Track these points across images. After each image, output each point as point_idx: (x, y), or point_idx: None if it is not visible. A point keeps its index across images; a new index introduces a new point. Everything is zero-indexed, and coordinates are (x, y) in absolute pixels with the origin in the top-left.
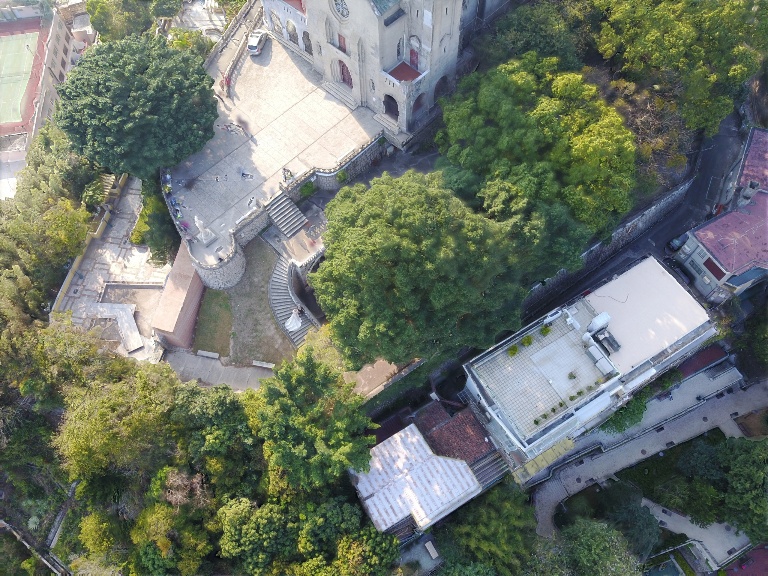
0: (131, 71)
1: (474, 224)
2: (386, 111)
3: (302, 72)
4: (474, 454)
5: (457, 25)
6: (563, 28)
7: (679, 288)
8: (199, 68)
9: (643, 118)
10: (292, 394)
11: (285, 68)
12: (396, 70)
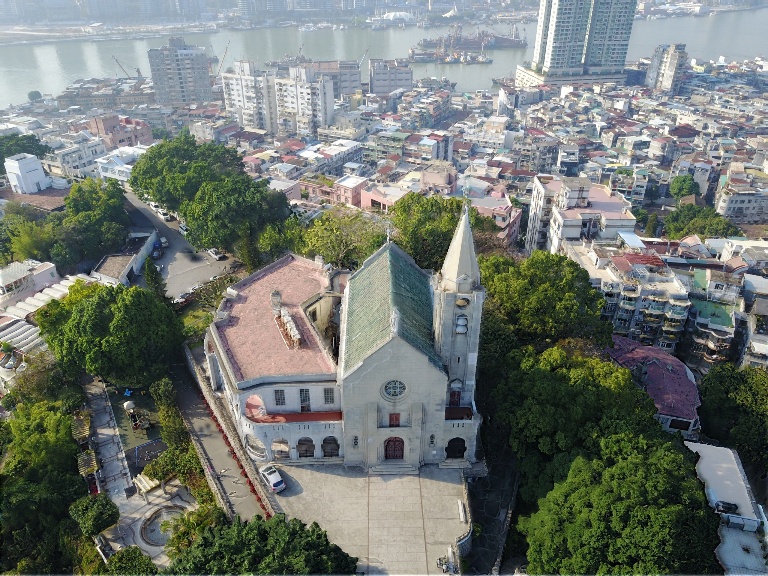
0: None
1: (676, 463)
2: (447, 456)
3: (340, 475)
4: None
5: None
6: None
7: (698, 445)
8: (297, 522)
9: None
10: None
11: (321, 482)
12: (446, 416)
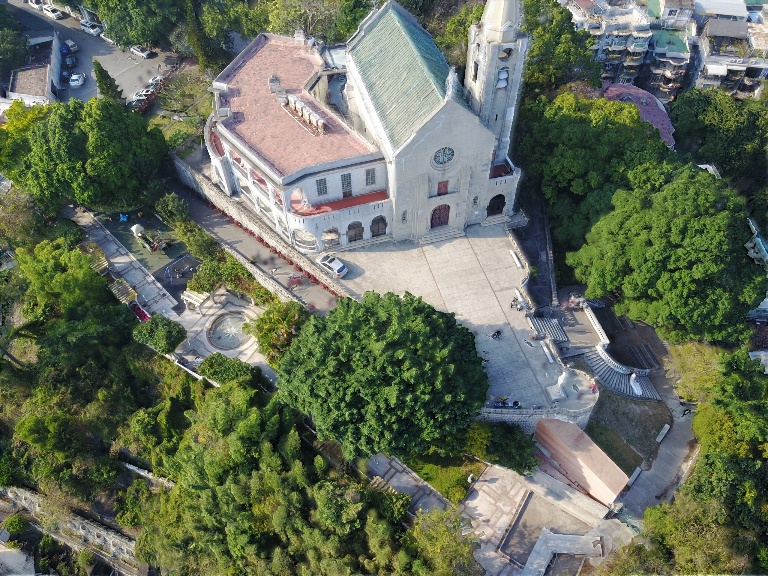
0: (395, 331)
1: (712, 178)
2: (487, 214)
3: (393, 250)
4: (767, 336)
5: None
6: None
7: None
8: (391, 295)
9: None
10: (739, 399)
11: (379, 260)
12: None
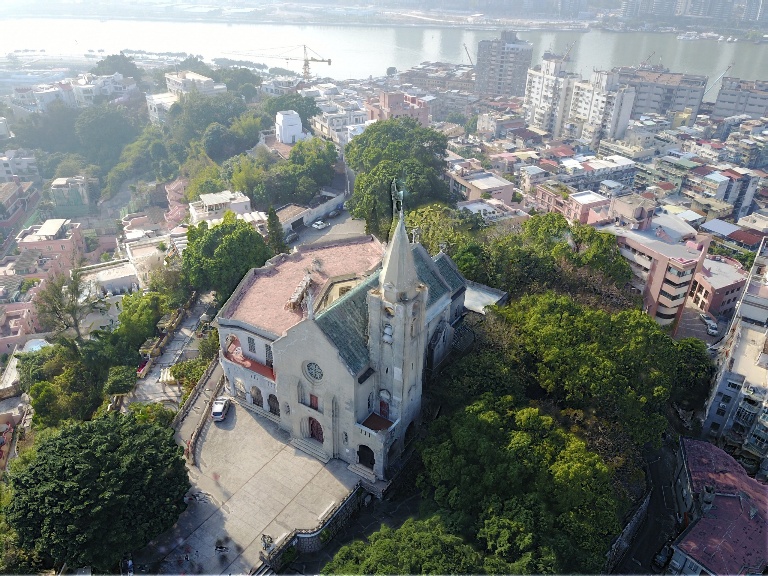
0: (103, 451)
1: (496, 570)
2: (360, 461)
3: (269, 432)
4: None
5: (420, 377)
6: (507, 371)
7: None
8: (171, 440)
9: (598, 440)
10: None
11: (251, 430)
12: (368, 421)
